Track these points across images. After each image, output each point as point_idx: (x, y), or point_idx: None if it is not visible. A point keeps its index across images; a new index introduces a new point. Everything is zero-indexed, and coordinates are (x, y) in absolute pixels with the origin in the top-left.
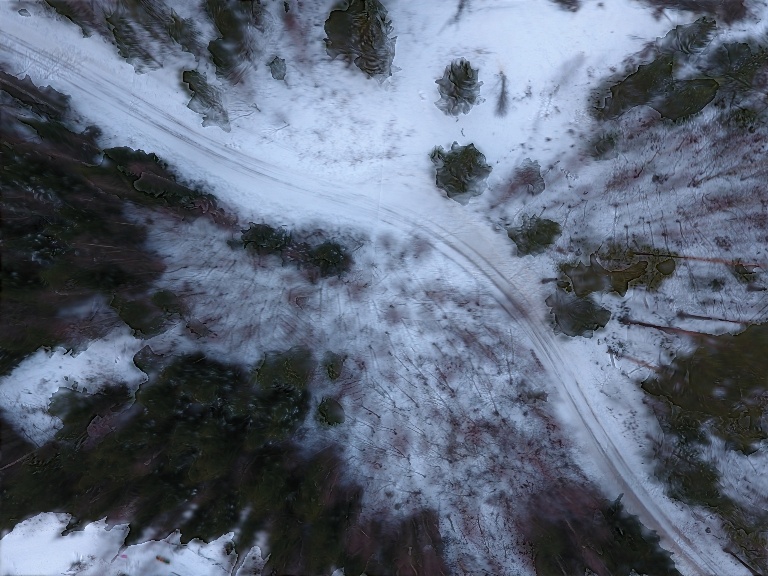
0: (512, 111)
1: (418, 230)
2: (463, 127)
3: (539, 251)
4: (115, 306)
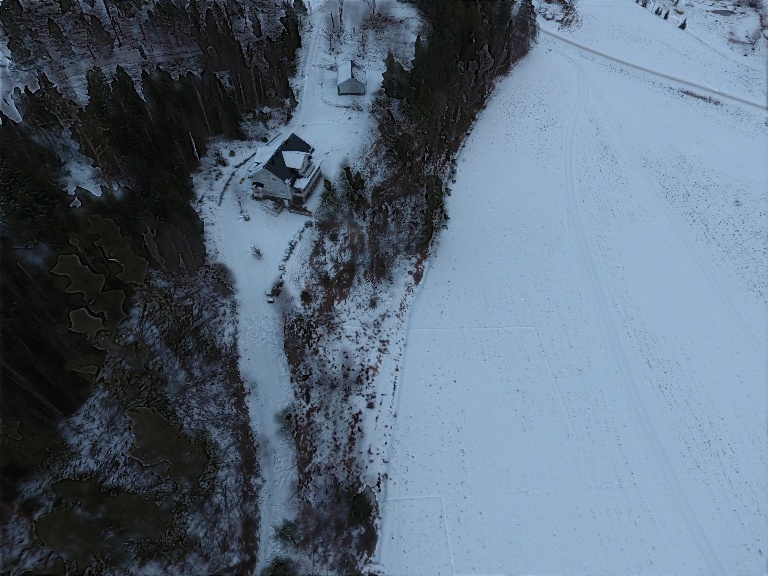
0: (6, 64)
1: (54, 85)
2: (7, 76)
3: (67, 39)
4: (29, 114)
